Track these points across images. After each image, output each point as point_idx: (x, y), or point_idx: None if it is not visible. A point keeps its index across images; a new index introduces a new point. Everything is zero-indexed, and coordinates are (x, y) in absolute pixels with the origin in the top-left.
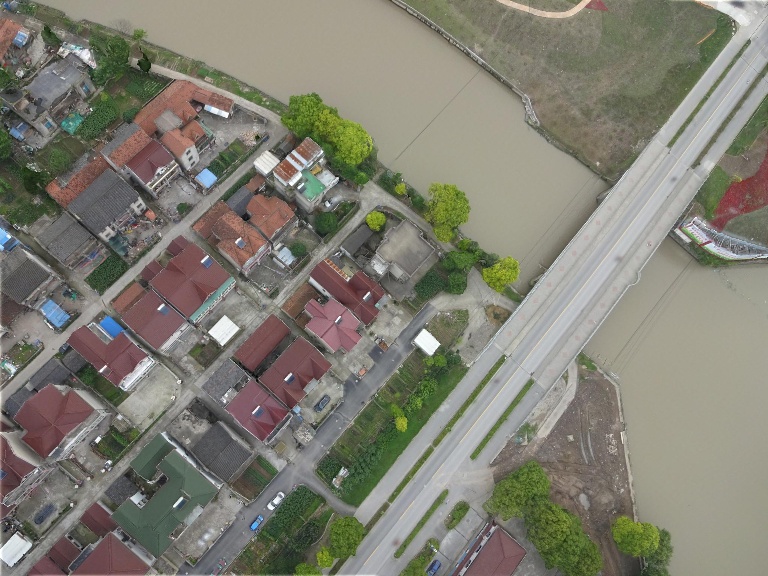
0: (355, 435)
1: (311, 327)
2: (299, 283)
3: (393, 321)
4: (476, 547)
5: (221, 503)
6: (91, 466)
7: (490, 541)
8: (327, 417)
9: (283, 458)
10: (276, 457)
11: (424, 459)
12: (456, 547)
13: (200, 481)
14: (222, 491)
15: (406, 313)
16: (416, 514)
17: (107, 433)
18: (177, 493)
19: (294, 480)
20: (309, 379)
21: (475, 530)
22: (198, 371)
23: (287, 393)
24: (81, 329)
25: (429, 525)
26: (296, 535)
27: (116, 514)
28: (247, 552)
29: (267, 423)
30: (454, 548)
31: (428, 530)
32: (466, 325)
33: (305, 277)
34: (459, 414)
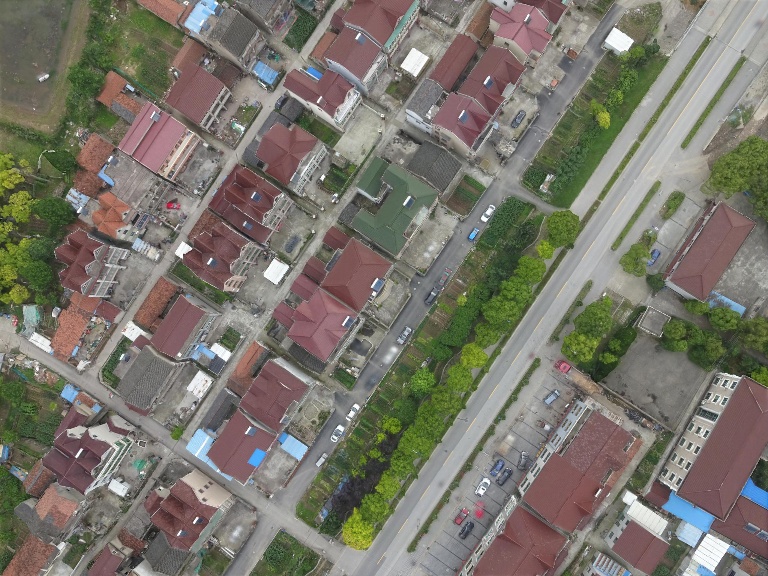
0: (555, 145)
1: (500, 34)
2: (478, 7)
3: (579, 28)
4: (698, 228)
5: (438, 220)
6: (321, 201)
7: (714, 216)
8: (525, 131)
9: (489, 174)
10: (482, 175)
11: (631, 154)
12: (674, 236)
13: (421, 186)
14: (437, 210)
15: (592, 18)
16: (629, 208)
17: (329, 172)
18: (404, 195)
19: (502, 194)
20: (506, 82)
21: (693, 218)
22: (397, 107)
23: (487, 98)
24: (293, 72)
25: (644, 217)
26: (514, 234)
27: (355, 221)
28: (469, 260)
29: (473, 129)
30: (672, 237)
31: (643, 222)
32: (660, 17)
33: (483, 0)
34: (664, 103)
